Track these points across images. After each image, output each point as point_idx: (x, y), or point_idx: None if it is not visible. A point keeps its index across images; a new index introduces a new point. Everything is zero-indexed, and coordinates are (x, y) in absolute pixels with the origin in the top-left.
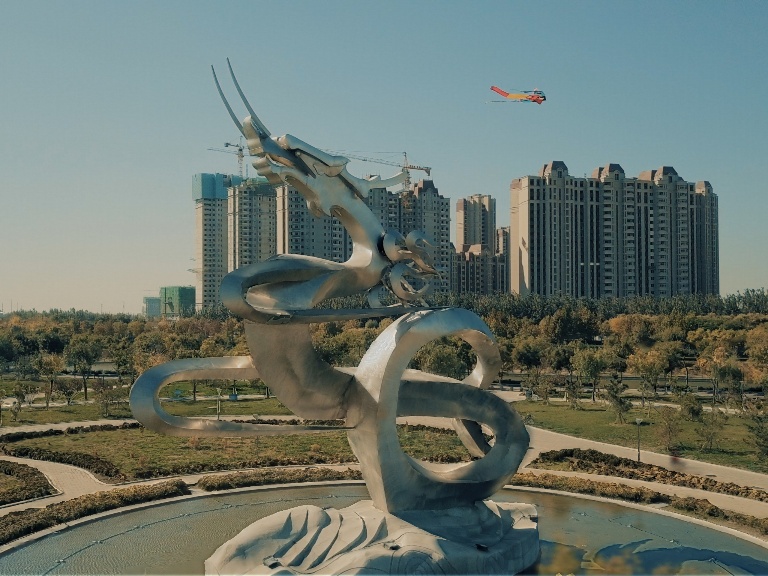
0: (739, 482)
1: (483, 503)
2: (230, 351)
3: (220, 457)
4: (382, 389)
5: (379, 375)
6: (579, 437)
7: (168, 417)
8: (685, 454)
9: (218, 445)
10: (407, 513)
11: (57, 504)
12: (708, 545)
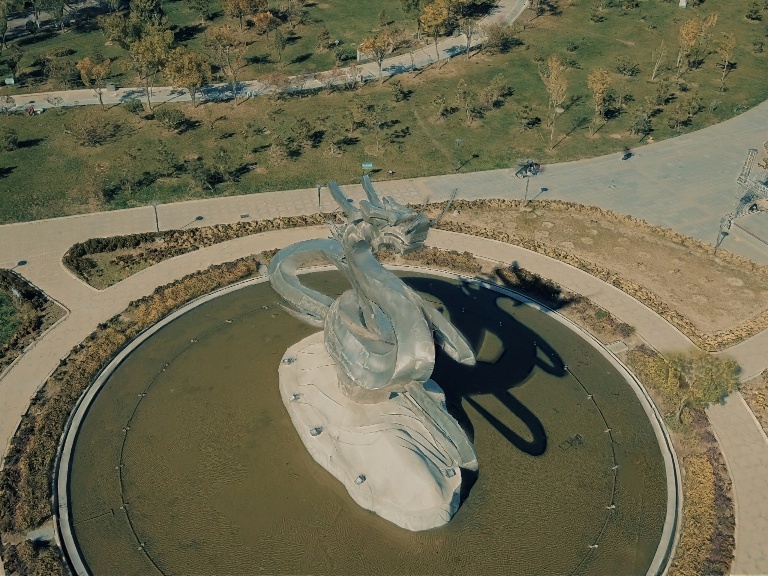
0: (227, 216)
1: None
2: None
3: None
4: None
5: None
6: (4, 223)
7: None
8: (127, 202)
9: None
10: None
11: None
12: None
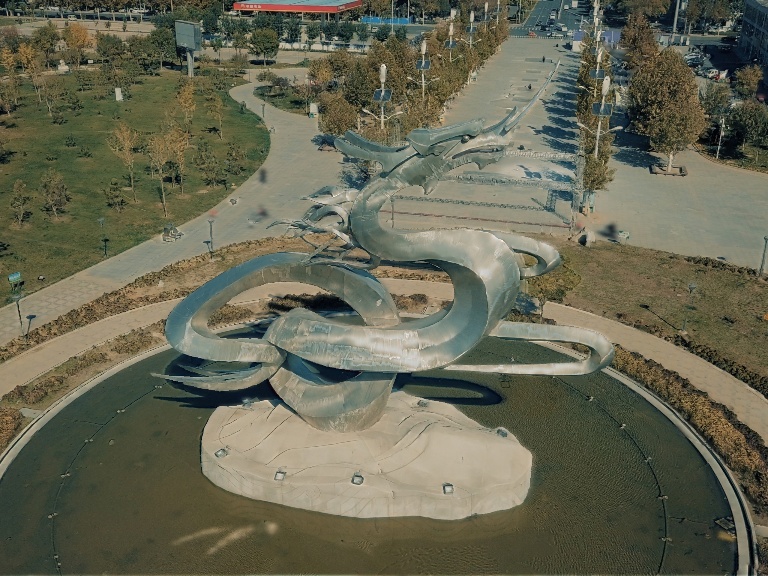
0: None
1: None
2: None
3: None
4: None
5: None
6: None
7: None
8: None
9: None
10: None
11: None
12: None
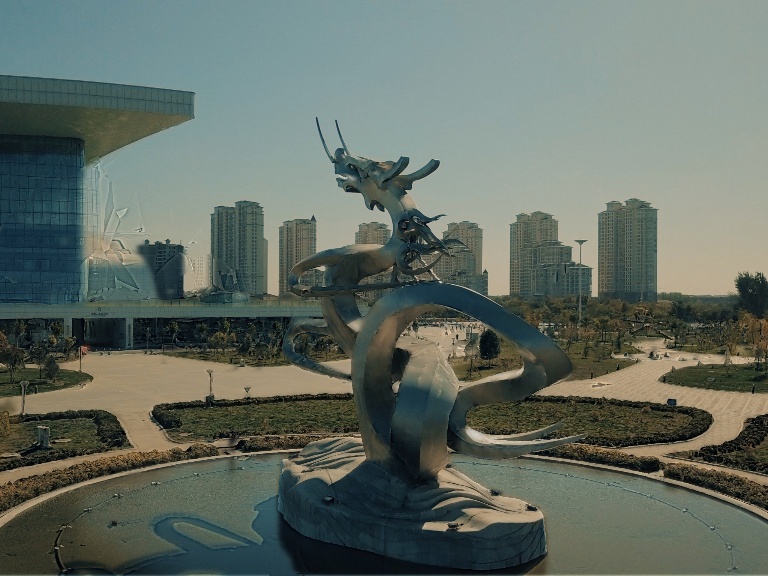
0: None
1: (430, 488)
2: None
3: None
4: None
5: None
6: None
7: None
8: None
9: None
10: None
11: None
12: None
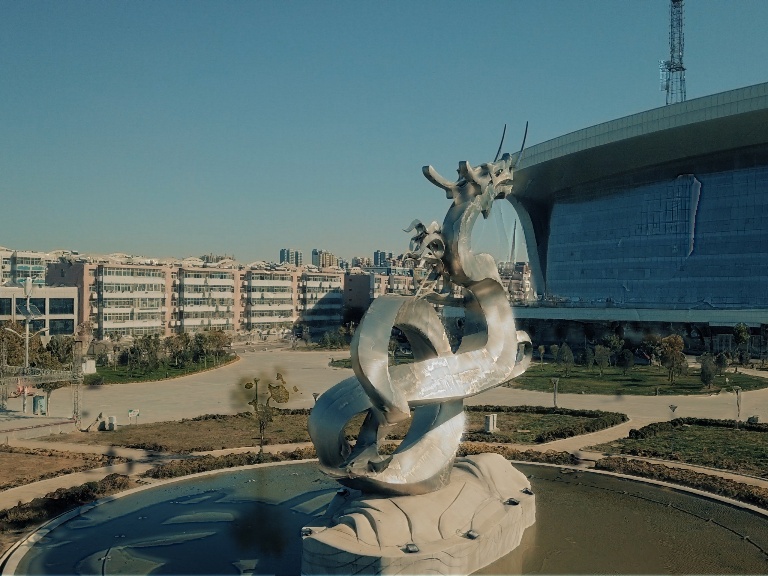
0: None
1: (357, 500)
2: None
3: None
4: None
5: None
6: None
7: None
8: None
9: None
10: None
11: None
12: None
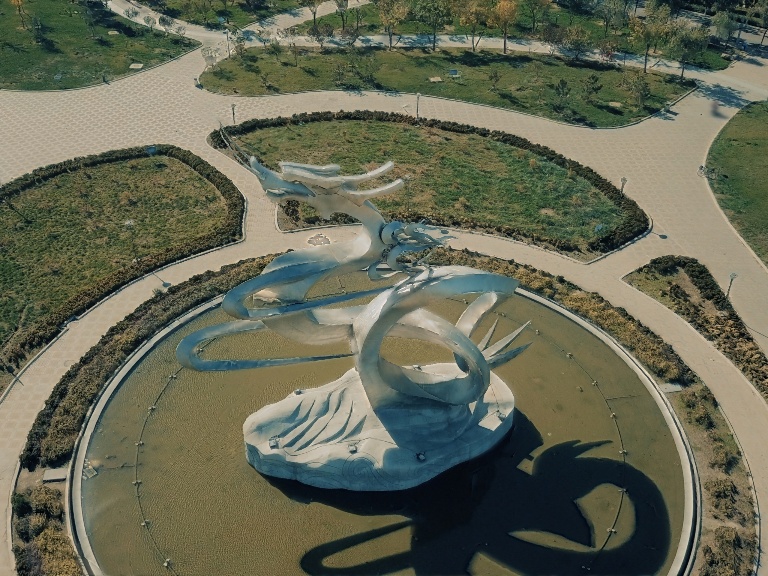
0: None
1: None
2: (472, 2)
3: (383, 196)
4: (364, 347)
5: (363, 336)
6: (732, 223)
7: (202, 364)
8: None
9: (392, 172)
10: (386, 412)
11: (227, 269)
12: (646, 466)
